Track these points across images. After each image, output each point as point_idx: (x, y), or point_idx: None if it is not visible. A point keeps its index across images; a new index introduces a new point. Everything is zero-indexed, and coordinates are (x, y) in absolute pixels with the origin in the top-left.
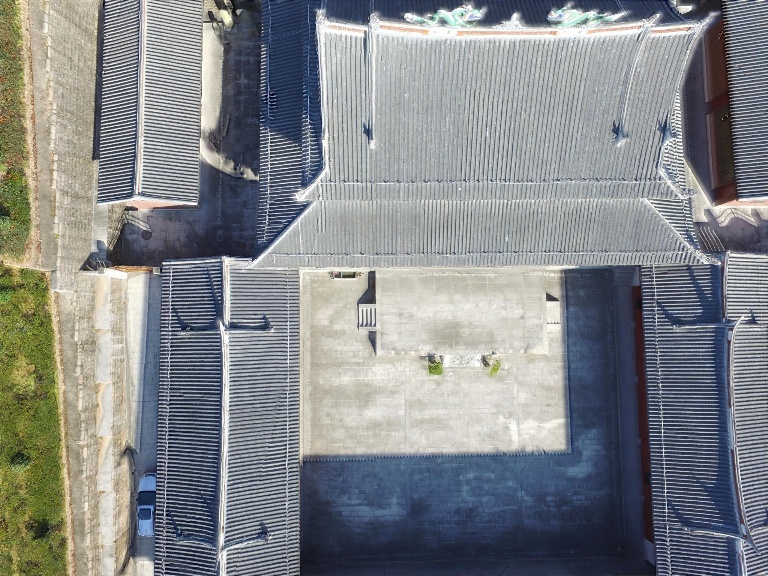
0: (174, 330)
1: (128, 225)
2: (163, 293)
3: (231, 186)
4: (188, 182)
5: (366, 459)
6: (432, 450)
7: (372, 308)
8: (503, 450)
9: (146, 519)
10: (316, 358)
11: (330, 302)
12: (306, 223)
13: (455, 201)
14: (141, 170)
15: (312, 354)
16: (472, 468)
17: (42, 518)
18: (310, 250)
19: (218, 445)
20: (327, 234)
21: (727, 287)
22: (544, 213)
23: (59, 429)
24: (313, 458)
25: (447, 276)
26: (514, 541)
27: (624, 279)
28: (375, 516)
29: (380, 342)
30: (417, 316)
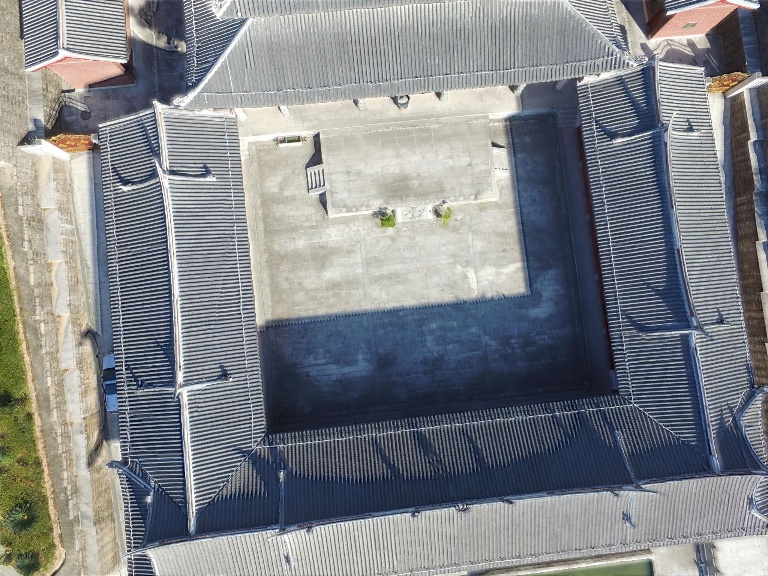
0: (116, 189)
1: (66, 107)
2: (102, 155)
3: (166, 60)
4: (115, 40)
5: (328, 319)
6: (393, 304)
7: (320, 169)
8: (463, 298)
9: (113, 394)
10: (269, 225)
11: (278, 169)
12: (234, 58)
13: (381, 23)
14: (64, 27)
15: (265, 222)
16: (434, 318)
17: (3, 390)
18: (241, 88)
19: (169, 291)
20: (256, 70)
21: (661, 95)
22: (471, 29)
23: (13, 305)
24: (275, 323)
25: (391, 131)
26: (481, 385)
27: (568, 120)
28: (342, 373)
29: (330, 201)
30: (365, 172)
